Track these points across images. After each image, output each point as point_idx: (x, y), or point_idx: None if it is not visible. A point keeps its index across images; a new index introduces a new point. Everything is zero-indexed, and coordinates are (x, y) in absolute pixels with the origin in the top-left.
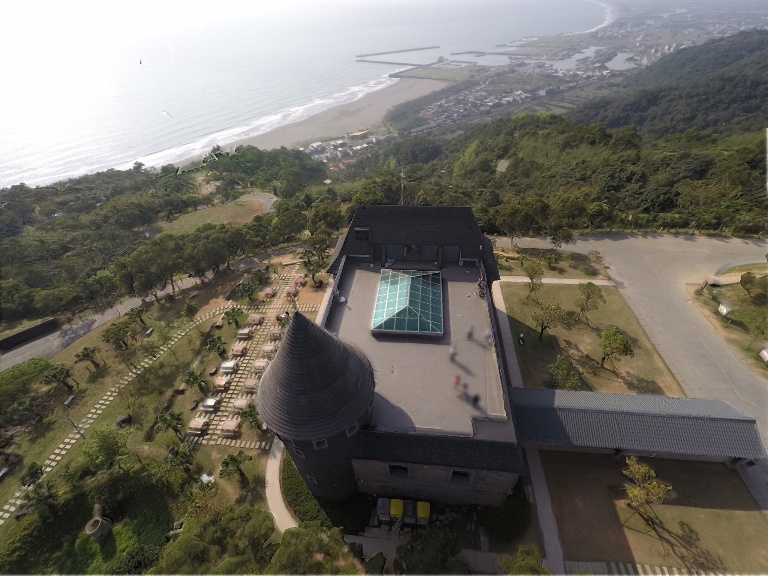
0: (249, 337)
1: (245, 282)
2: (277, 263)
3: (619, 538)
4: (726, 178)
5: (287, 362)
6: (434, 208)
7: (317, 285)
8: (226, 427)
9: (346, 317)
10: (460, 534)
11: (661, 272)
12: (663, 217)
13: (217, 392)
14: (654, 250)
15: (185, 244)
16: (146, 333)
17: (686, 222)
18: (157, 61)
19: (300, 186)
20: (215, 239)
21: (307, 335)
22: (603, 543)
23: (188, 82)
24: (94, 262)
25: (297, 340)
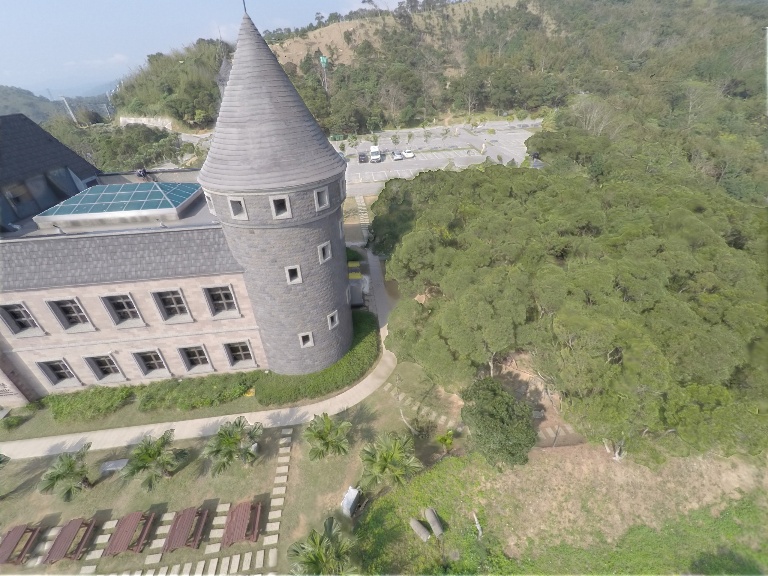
0: None
1: None
2: None
3: (349, 226)
4: None
5: (287, 84)
6: None
7: None
8: (244, 523)
9: None
10: (361, 271)
11: None
12: None
13: None
14: None
15: None
16: None
17: None
18: None
19: None
20: None
21: None
22: (353, 230)
23: None
24: None
25: None
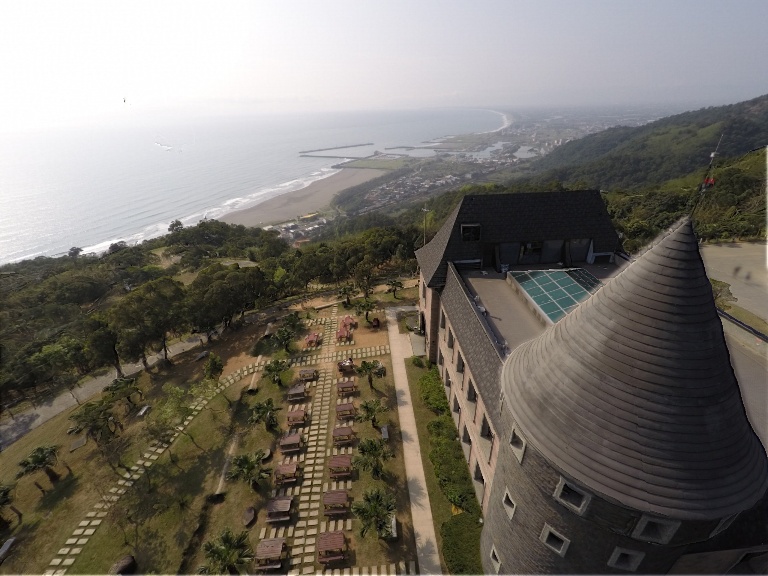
0: (305, 398)
1: (281, 328)
2: (307, 308)
3: None
4: (714, 201)
5: (667, 337)
6: (557, 193)
7: (375, 324)
8: (328, 546)
9: (503, 329)
10: None
11: (737, 275)
12: (701, 228)
13: (284, 487)
14: (710, 258)
15: (186, 291)
16: (139, 415)
17: (715, 234)
18: (145, 100)
19: (283, 247)
20: (233, 278)
21: (704, 272)
22: None
23: (182, 120)
24: (33, 340)
25: (693, 282)
